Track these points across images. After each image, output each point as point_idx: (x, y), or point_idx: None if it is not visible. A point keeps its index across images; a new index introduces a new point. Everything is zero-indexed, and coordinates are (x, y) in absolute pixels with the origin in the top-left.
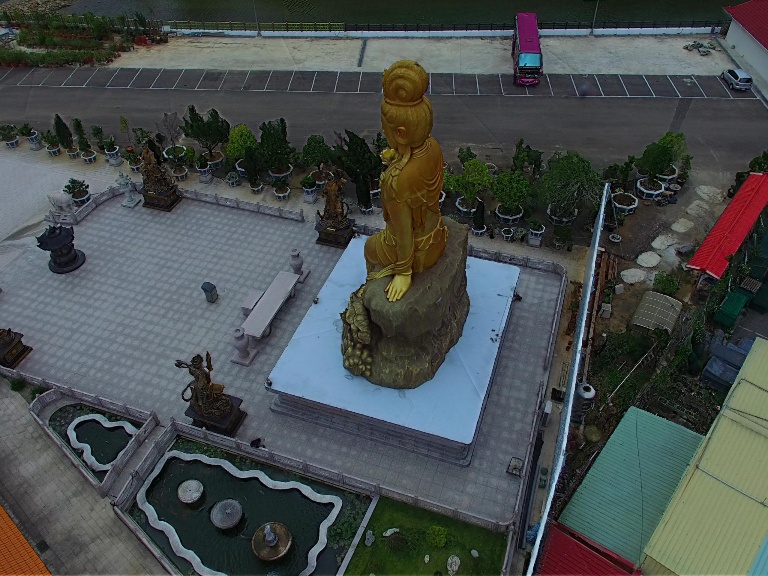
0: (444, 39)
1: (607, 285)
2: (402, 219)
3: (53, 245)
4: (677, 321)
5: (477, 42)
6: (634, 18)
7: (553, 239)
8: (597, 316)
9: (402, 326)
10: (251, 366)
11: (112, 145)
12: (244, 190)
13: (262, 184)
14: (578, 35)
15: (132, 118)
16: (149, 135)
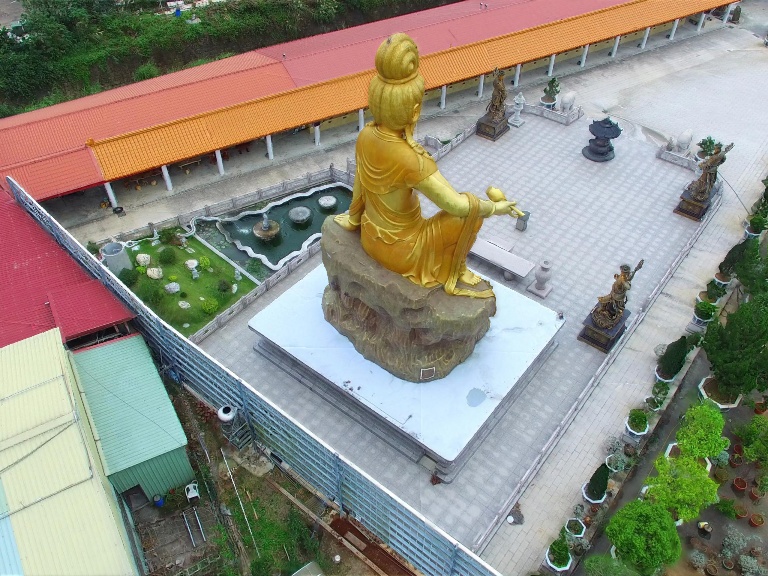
0: None
1: None
2: None
3: (593, 127)
4: None
5: None
6: None
7: None
8: (377, 575)
9: None
10: None
11: None
12: None
13: None
14: None
15: None
16: None
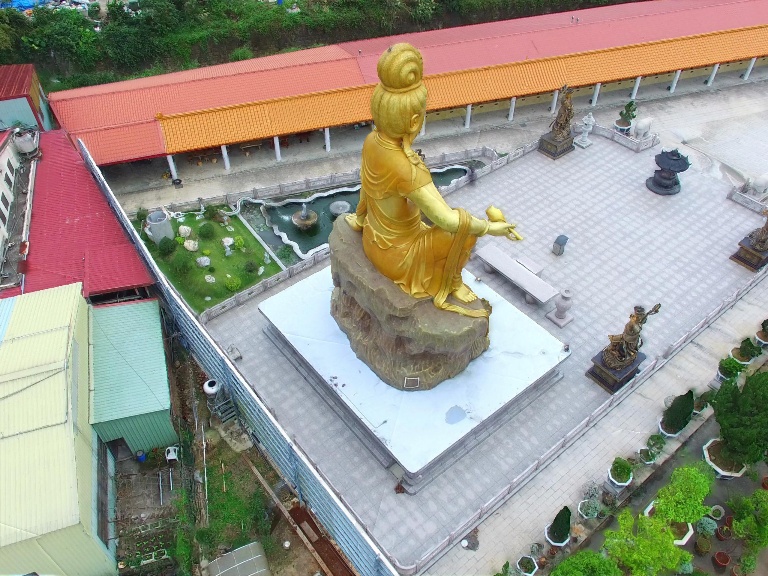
0: None
1: None
2: None
3: (660, 158)
4: None
5: None
6: None
7: None
8: (321, 569)
9: None
10: None
11: None
12: None
13: None
14: None
15: None
16: None
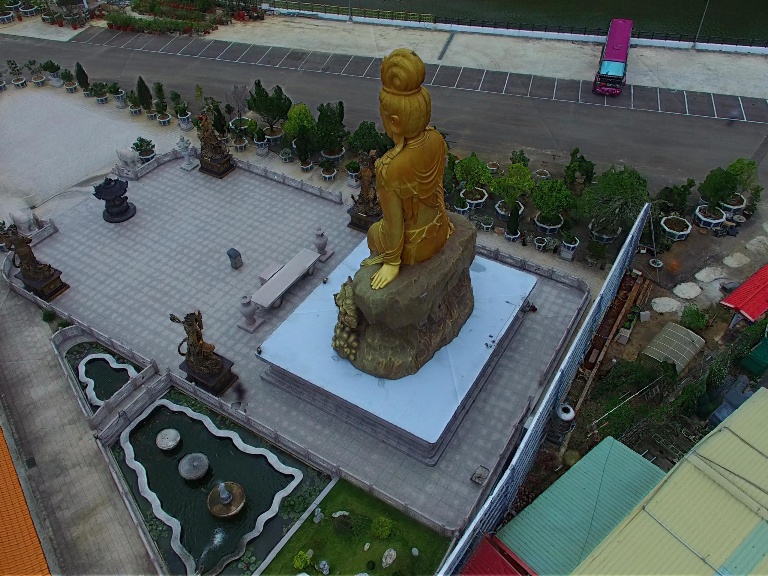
0: (533, 40)
1: (631, 310)
2: (391, 208)
3: (106, 195)
4: (699, 359)
5: (567, 46)
6: (744, 35)
7: (586, 255)
8: (613, 340)
9: (382, 315)
10: (254, 333)
11: (184, 110)
12: (295, 167)
13: (313, 163)
14: (678, 48)
15: (212, 88)
16: (219, 105)
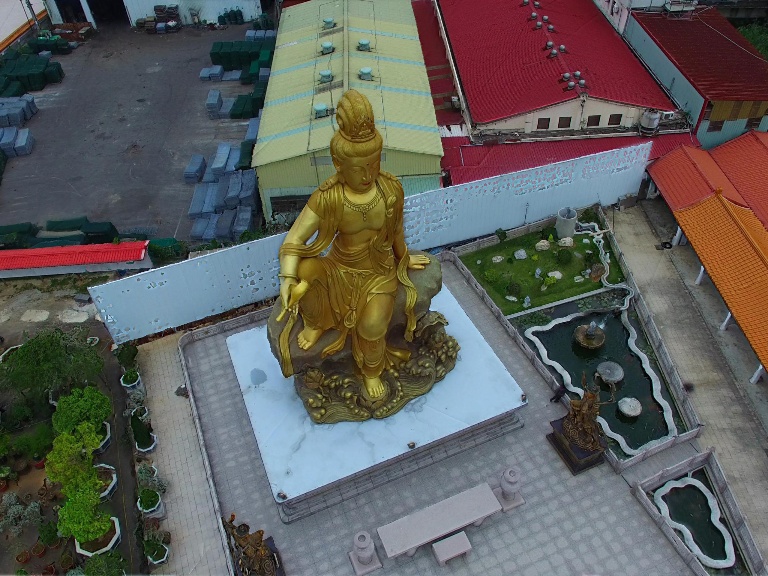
0: None
1: None
2: None
3: None
4: None
5: None
6: None
7: None
8: None
9: None
10: None
11: None
12: None
13: None
14: None
15: None
16: None
